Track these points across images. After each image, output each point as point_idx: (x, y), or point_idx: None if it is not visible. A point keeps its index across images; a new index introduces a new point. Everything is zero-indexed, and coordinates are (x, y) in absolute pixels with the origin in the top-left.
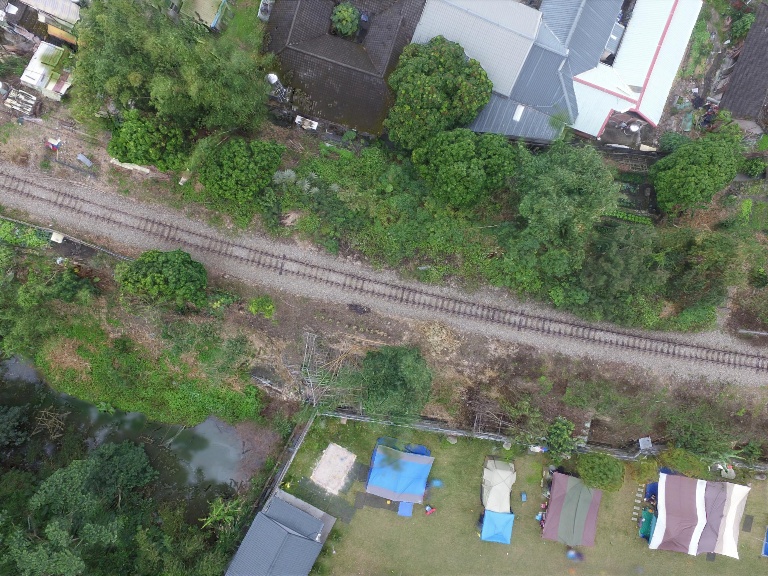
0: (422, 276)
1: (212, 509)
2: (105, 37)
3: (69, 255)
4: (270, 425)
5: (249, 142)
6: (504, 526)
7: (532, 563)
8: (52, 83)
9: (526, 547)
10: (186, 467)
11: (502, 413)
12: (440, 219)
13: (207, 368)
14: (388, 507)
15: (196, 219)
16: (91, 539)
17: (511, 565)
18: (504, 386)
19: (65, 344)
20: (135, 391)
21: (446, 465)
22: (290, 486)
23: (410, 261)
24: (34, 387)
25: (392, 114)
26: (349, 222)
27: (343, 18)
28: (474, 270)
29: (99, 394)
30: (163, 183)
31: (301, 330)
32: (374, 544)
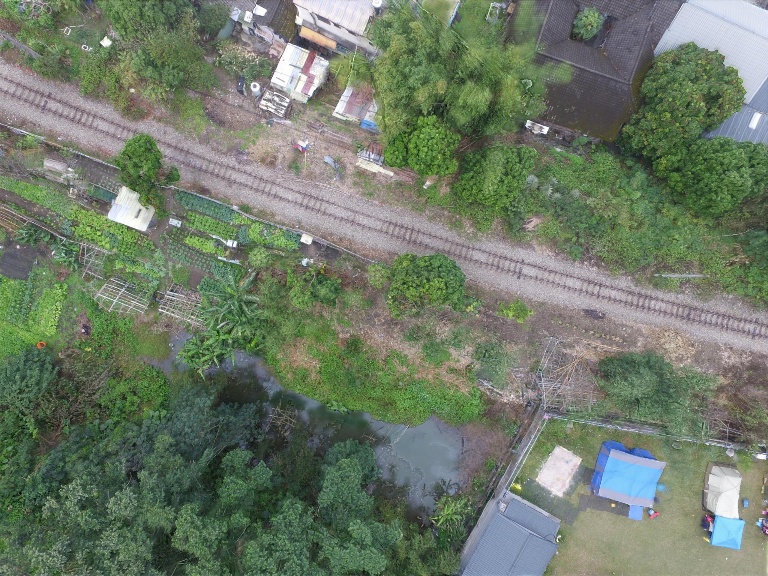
0: (664, 283)
1: (439, 508)
2: (420, 44)
3: (314, 256)
4: (499, 427)
5: (518, 148)
6: (737, 532)
7: (751, 568)
8: (300, 85)
9: (745, 552)
10: (405, 466)
11: (729, 420)
12: (684, 227)
13: (435, 370)
14: (611, 510)
15: (437, 222)
16: (379, 537)
17: (730, 570)
18: (733, 393)
19: (296, 343)
20: (363, 391)
21: (669, 470)
22: None
23: (647, 268)
24: (262, 385)
25: (643, 121)
26: (590, 228)
27: (589, 23)
28: (712, 278)
29: (328, 393)
30: (407, 186)
31: (536, 334)
32: (596, 546)
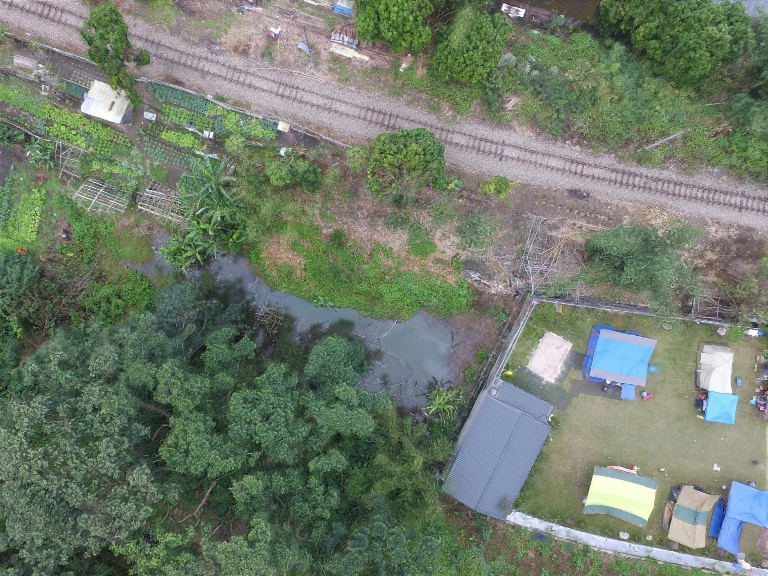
0: (647, 156)
1: (431, 399)
2: None
3: (292, 145)
4: (487, 315)
5: None
6: (731, 405)
7: (746, 447)
8: None
9: (740, 432)
10: (396, 363)
11: (719, 297)
12: (665, 97)
13: (421, 261)
14: (604, 394)
15: (415, 107)
16: (367, 405)
17: (726, 450)
18: (722, 269)
19: (280, 240)
20: (349, 286)
21: (660, 352)
22: (508, 375)
23: (630, 144)
24: (247, 285)
25: None
26: (571, 104)
27: None
28: (696, 150)
29: (314, 289)
30: (383, 70)
31: (520, 217)
32: (590, 431)
